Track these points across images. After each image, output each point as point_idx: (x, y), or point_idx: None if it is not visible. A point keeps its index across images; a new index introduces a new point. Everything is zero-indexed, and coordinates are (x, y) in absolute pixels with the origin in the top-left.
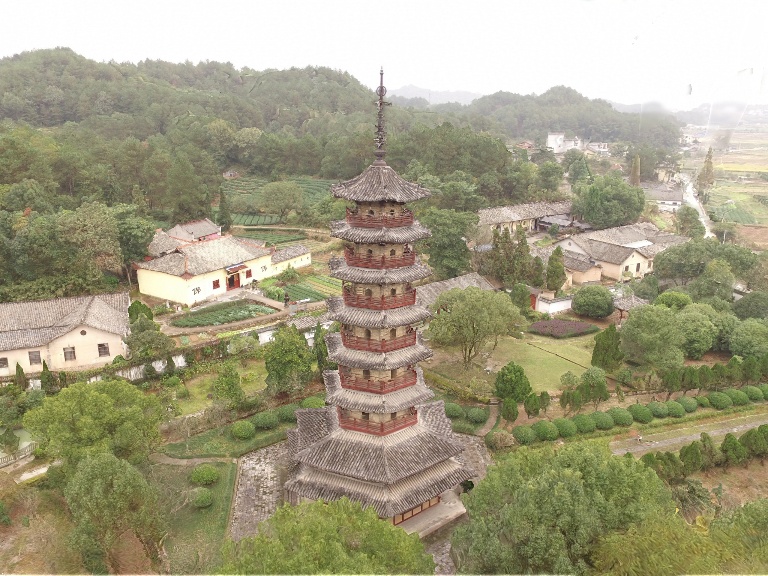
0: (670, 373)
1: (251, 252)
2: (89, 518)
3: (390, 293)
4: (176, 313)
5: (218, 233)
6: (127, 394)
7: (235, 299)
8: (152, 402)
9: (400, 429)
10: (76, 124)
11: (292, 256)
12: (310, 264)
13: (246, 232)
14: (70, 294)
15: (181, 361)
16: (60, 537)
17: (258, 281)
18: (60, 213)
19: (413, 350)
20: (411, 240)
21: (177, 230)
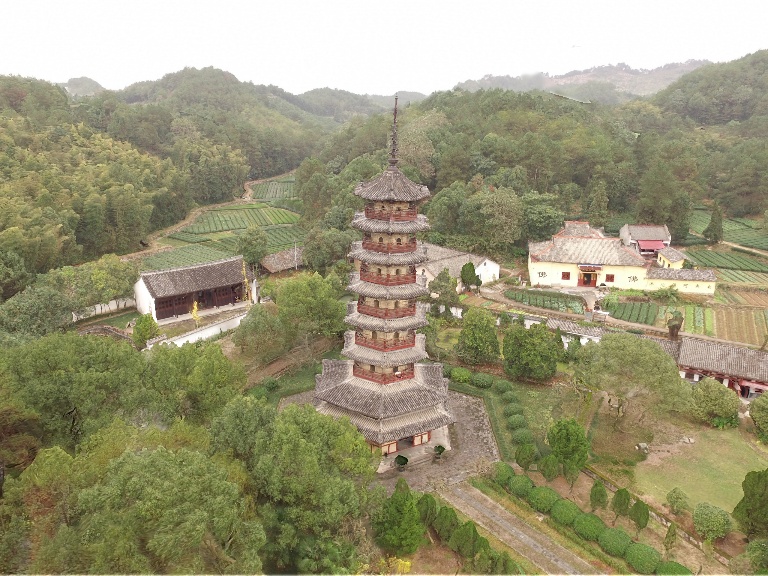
0: (764, 570)
1: (621, 259)
2: (238, 328)
3: (377, 271)
4: (518, 286)
5: (667, 241)
6: (319, 291)
7: (572, 293)
8: (329, 302)
9: (368, 379)
10: (739, 124)
11: (682, 278)
12: (712, 294)
13: (731, 251)
14: (477, 251)
15: (460, 313)
16: (268, 347)
17: (621, 288)
18: (486, 191)
19: (382, 322)
20: (374, 231)
21: (625, 229)
